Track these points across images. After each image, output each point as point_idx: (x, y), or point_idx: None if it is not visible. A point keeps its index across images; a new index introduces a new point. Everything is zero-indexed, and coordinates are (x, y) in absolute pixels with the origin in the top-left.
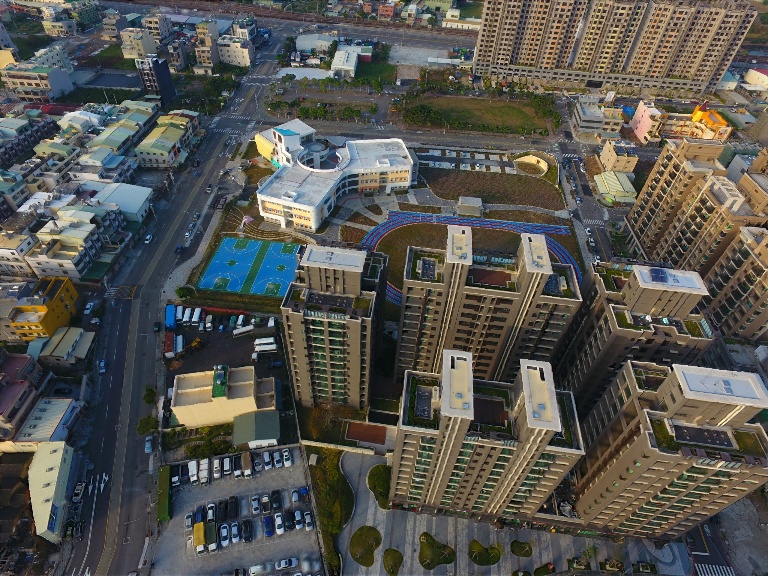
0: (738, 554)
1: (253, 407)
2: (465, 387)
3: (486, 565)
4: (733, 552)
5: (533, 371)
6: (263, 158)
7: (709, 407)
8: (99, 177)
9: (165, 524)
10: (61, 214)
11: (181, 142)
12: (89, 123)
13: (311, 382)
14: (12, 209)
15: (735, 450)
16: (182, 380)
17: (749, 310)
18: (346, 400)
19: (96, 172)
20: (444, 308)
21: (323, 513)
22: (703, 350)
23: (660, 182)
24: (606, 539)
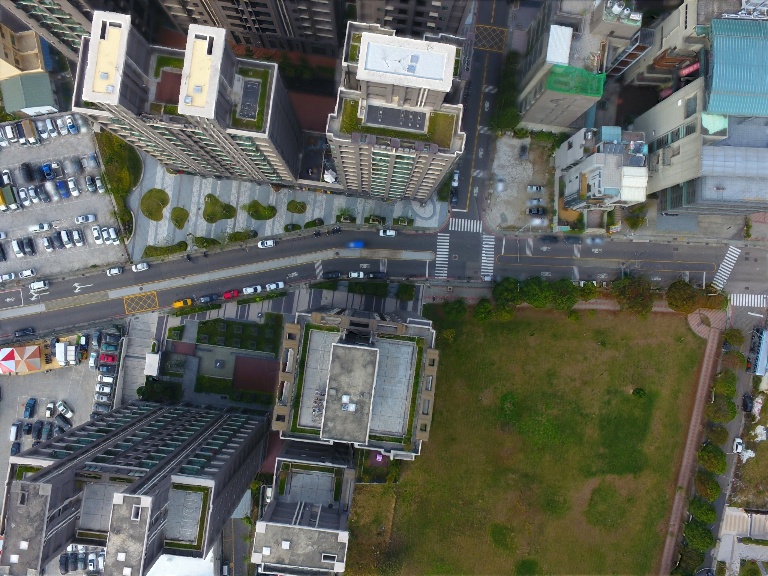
0: (494, 211)
1: (14, 70)
2: (113, 64)
3: (262, 220)
4: (490, 209)
5: (201, 41)
6: None
7: (395, 88)
8: None
9: None
10: None
11: None
12: None
13: (59, 39)
14: None
15: (420, 134)
16: None
17: None
18: None
19: None
20: None
21: (112, 178)
22: (470, 2)
23: None
24: (377, 199)
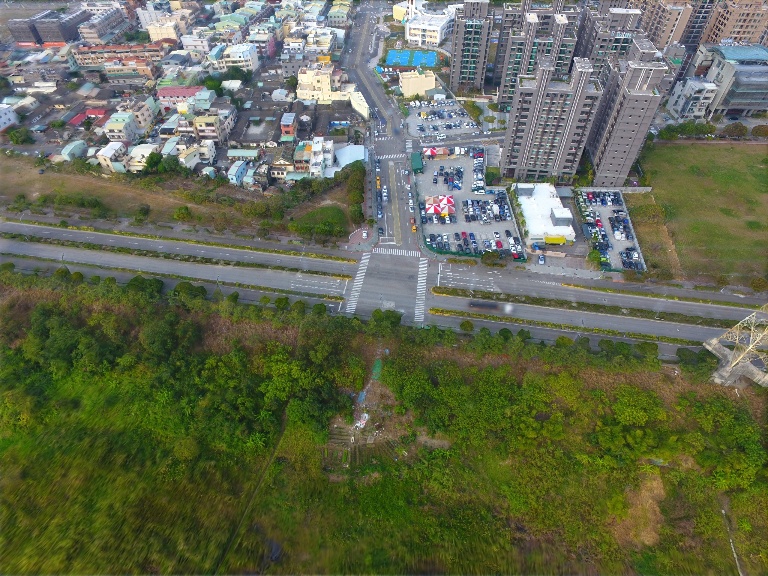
0: None
1: (433, 85)
2: None
3: None
4: None
5: (559, 15)
6: (396, 22)
7: (621, 19)
8: (316, 25)
9: (407, 116)
10: (314, 32)
11: (348, 13)
12: (296, 4)
13: (460, 71)
14: (277, 39)
15: None
16: (402, 75)
17: (660, 31)
18: (474, 85)
19: (315, 21)
20: (521, 26)
21: (471, 112)
22: None
23: (630, 0)
24: None
